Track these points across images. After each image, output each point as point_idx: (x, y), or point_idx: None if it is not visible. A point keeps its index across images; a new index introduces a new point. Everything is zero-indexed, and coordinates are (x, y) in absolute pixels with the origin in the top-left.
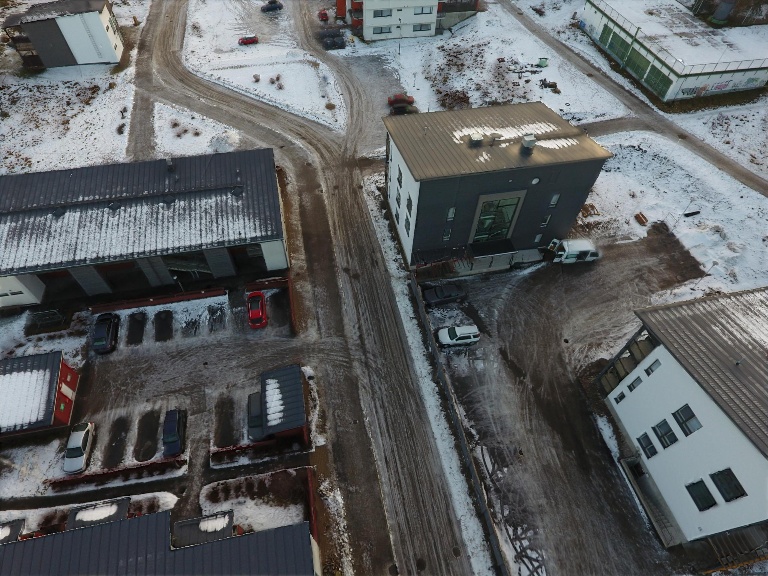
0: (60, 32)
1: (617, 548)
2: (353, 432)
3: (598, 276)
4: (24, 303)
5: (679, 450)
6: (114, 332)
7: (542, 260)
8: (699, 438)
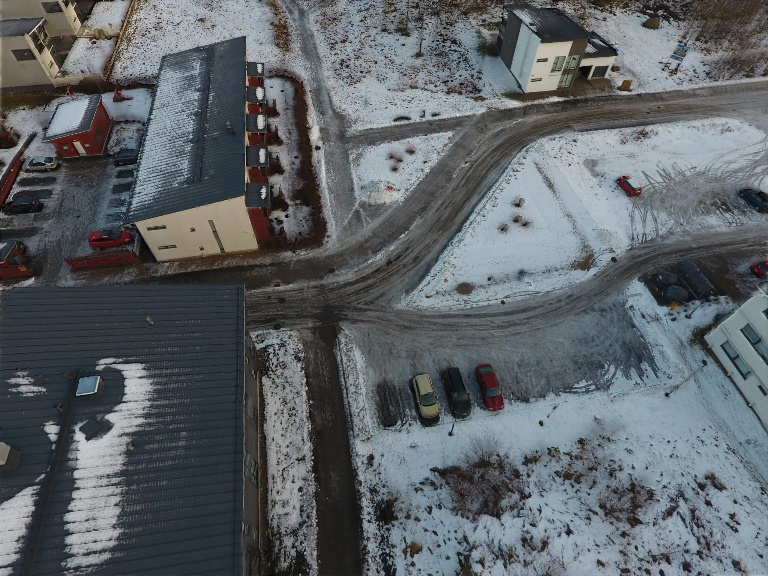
0: (518, 36)
1: None
2: None
3: None
4: None
5: None
6: (131, 162)
7: None
8: None
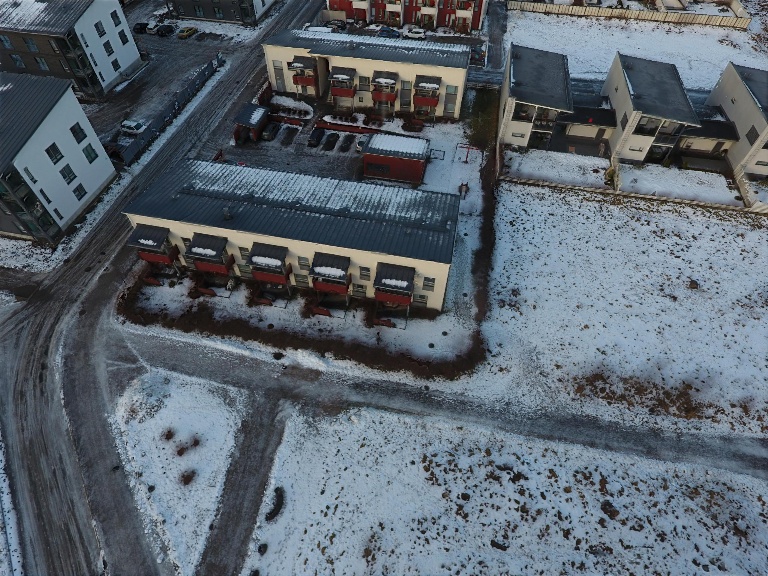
0: None
1: None
2: (230, 117)
3: None
4: None
5: None
6: None
7: None
8: None
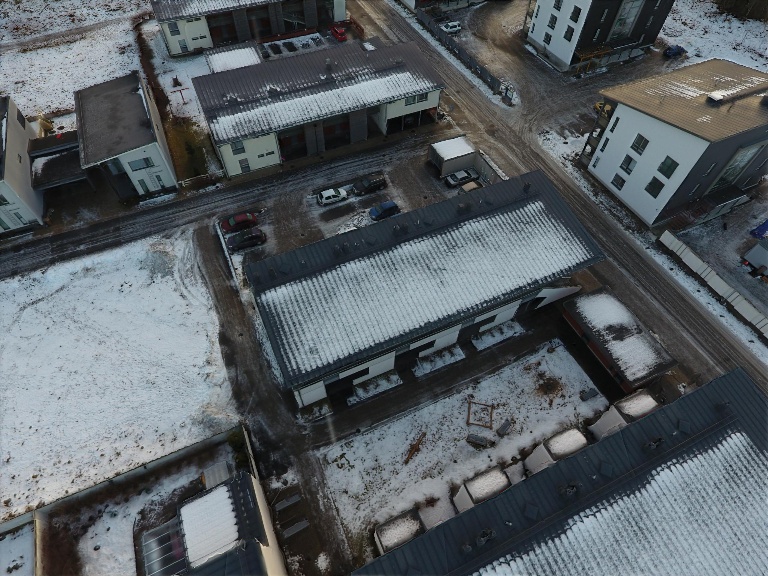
0: None
1: (541, 76)
2: None
3: (515, 3)
4: (204, 47)
5: (559, 24)
6: None
7: (484, 1)
8: (564, 6)
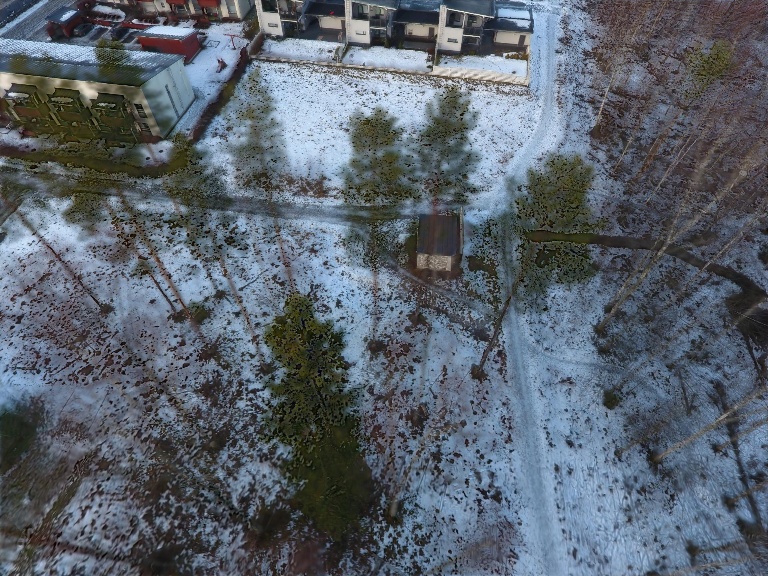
0: None
1: None
2: None
3: None
4: None
5: None
6: None
7: None
8: None
